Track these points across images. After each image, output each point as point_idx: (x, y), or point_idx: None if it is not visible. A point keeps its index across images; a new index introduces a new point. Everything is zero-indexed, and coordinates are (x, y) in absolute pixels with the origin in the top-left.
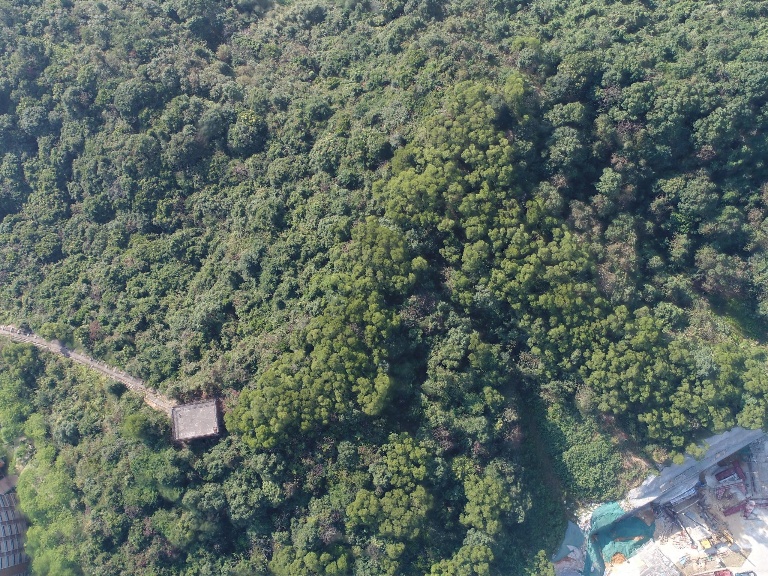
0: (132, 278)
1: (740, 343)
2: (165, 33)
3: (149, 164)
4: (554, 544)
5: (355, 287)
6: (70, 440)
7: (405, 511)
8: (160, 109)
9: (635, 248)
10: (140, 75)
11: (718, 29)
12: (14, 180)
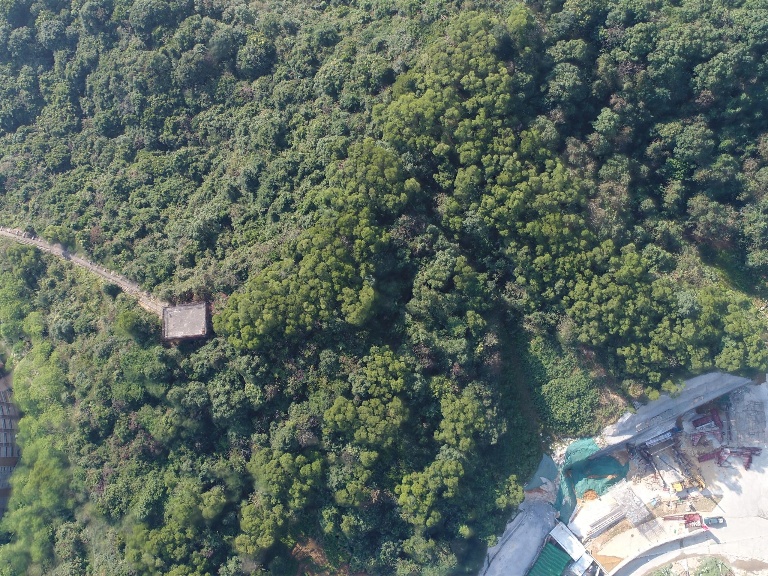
0: (135, 189)
1: None
2: None
3: (159, 81)
4: (527, 473)
5: (347, 202)
6: (65, 337)
7: (380, 420)
8: (173, 28)
9: (629, 192)
10: None
11: None
12: (29, 92)
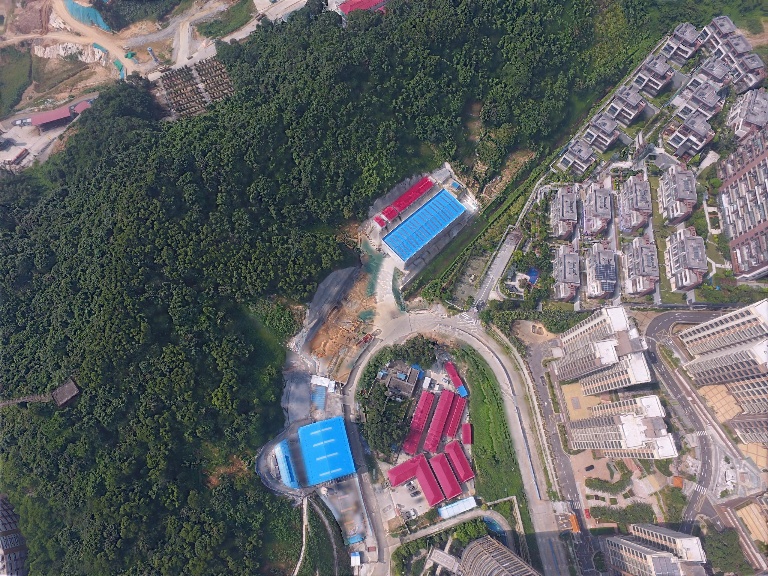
0: None
1: None
2: None
3: (1, 298)
4: (280, 362)
5: (114, 294)
6: (12, 444)
7: None
8: None
9: None
10: None
11: None
12: None
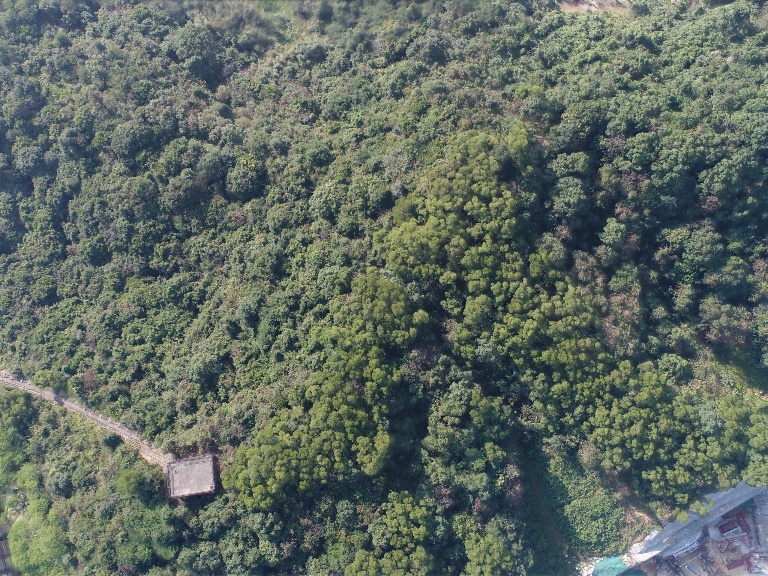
0: (128, 324)
1: (744, 393)
2: (164, 74)
3: (146, 207)
4: None
5: (355, 342)
6: (63, 492)
7: (405, 573)
8: (158, 151)
9: None
10: (138, 117)
11: (723, 77)
12: (9, 220)
